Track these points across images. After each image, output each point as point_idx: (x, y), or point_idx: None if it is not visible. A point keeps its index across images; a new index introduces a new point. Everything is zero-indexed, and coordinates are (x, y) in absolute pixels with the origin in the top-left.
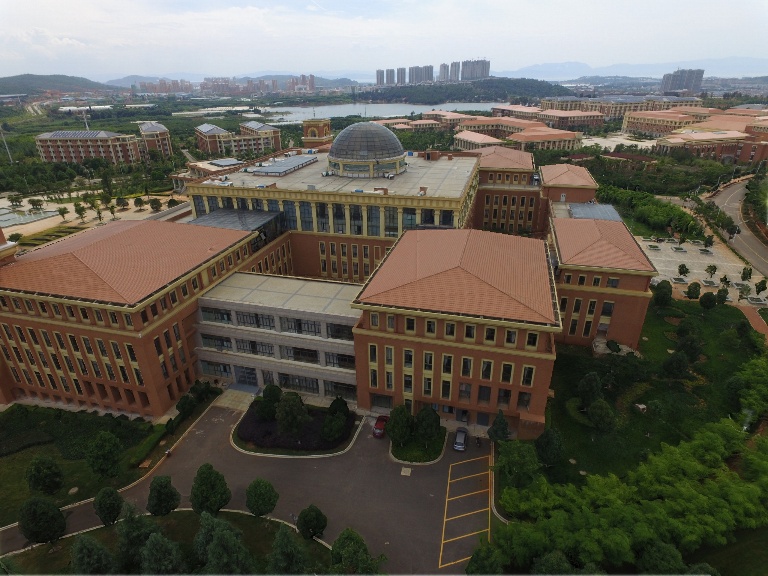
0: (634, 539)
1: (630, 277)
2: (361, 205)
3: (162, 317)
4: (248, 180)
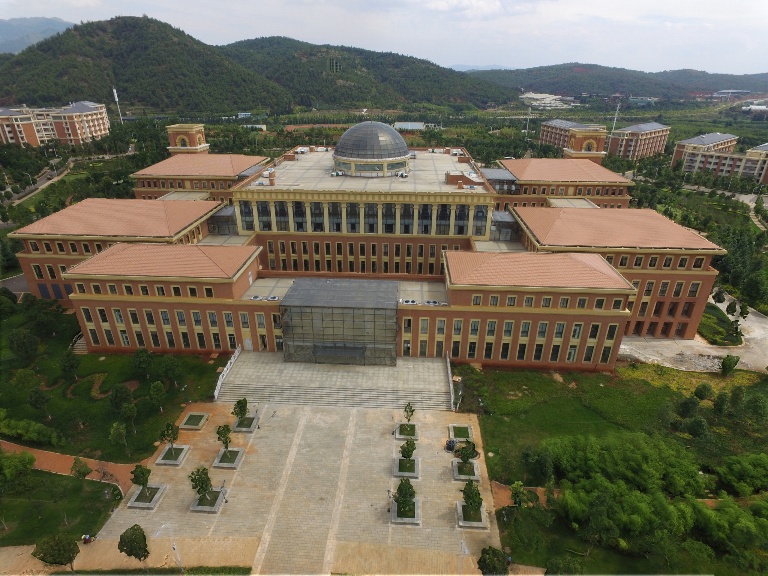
0: None
1: None
2: None
3: (148, 188)
4: (325, 154)
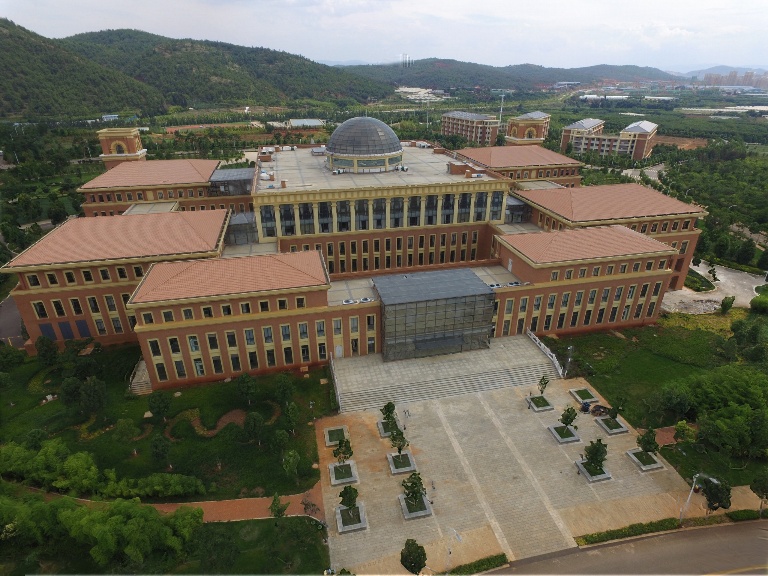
0: None
1: None
2: None
3: (101, 203)
4: (295, 153)
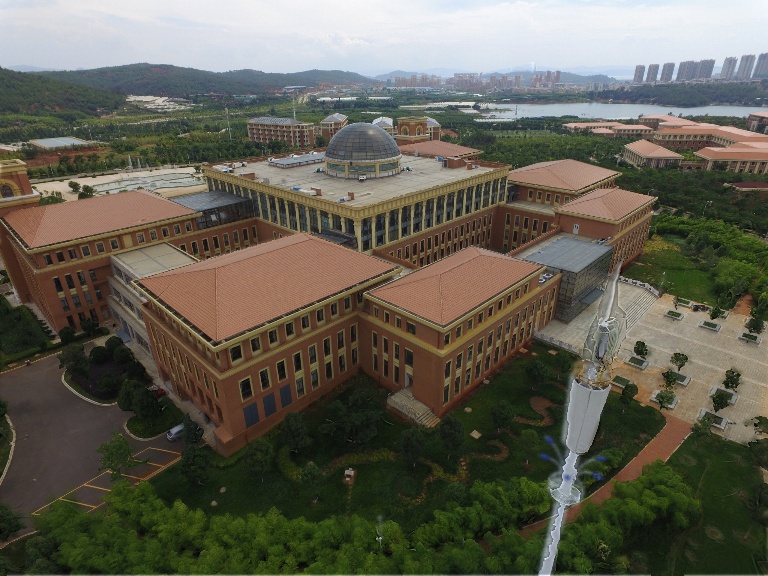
0: (92, 562)
1: (423, 326)
2: (294, 202)
3: (64, 263)
4: (256, 169)
